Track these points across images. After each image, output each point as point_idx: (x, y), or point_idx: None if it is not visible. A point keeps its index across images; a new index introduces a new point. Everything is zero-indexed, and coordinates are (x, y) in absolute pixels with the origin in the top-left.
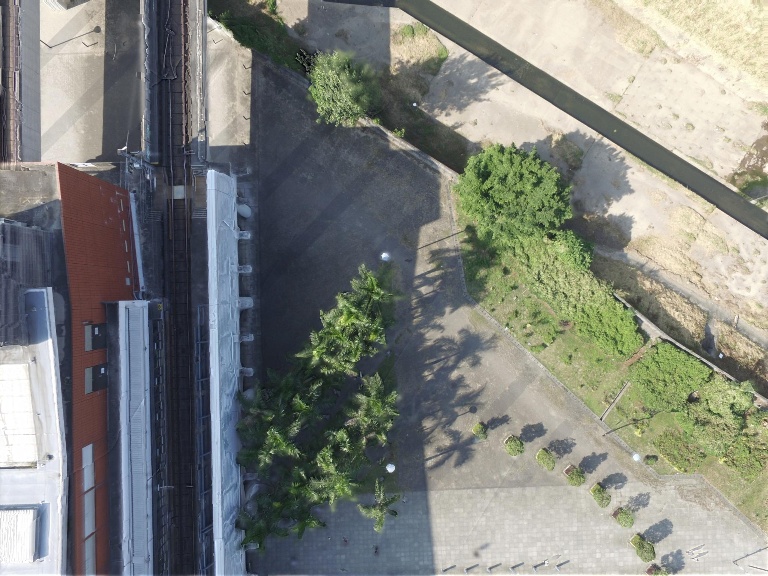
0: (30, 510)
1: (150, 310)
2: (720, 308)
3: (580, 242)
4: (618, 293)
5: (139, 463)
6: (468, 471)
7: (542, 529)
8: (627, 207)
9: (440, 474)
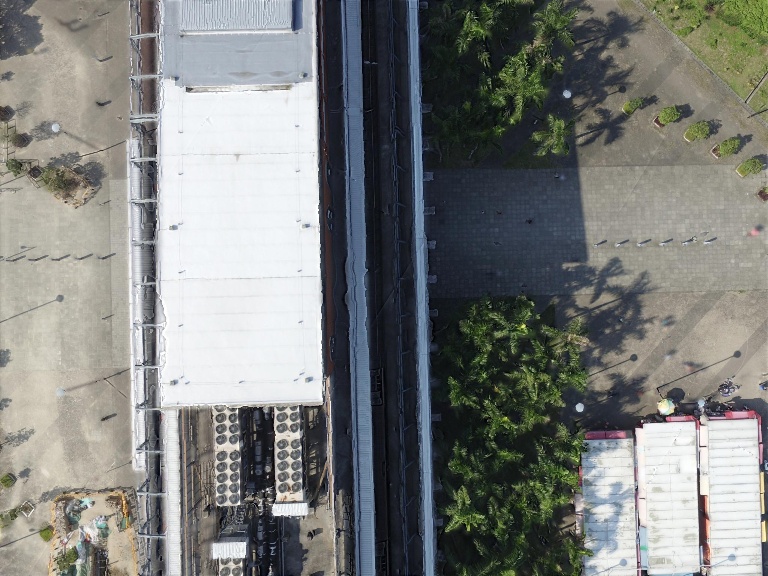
0: None
1: None
2: None
3: None
4: None
5: (354, 16)
6: (618, 149)
7: (690, 207)
8: None
9: (591, 151)
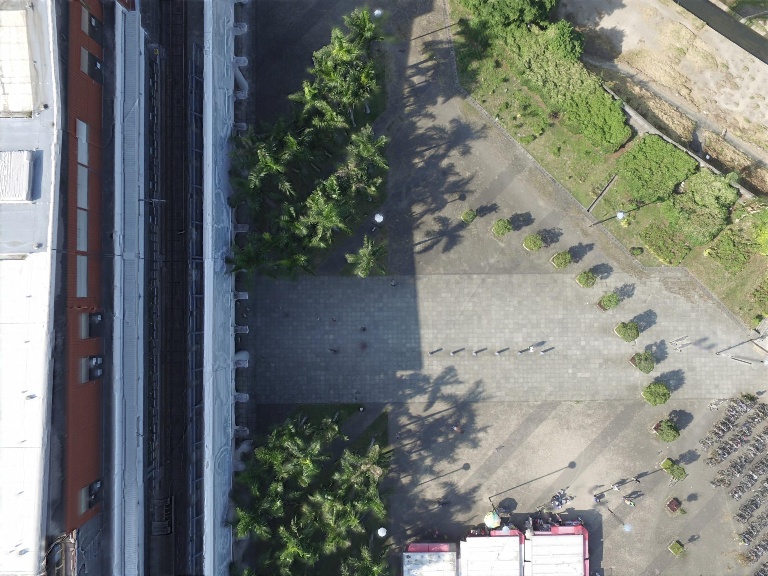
0: (24, 151)
1: (146, 45)
2: (708, 121)
3: (570, 26)
4: (607, 84)
5: (132, 162)
6: (456, 257)
7: (528, 316)
8: (619, 21)
9: (429, 259)
